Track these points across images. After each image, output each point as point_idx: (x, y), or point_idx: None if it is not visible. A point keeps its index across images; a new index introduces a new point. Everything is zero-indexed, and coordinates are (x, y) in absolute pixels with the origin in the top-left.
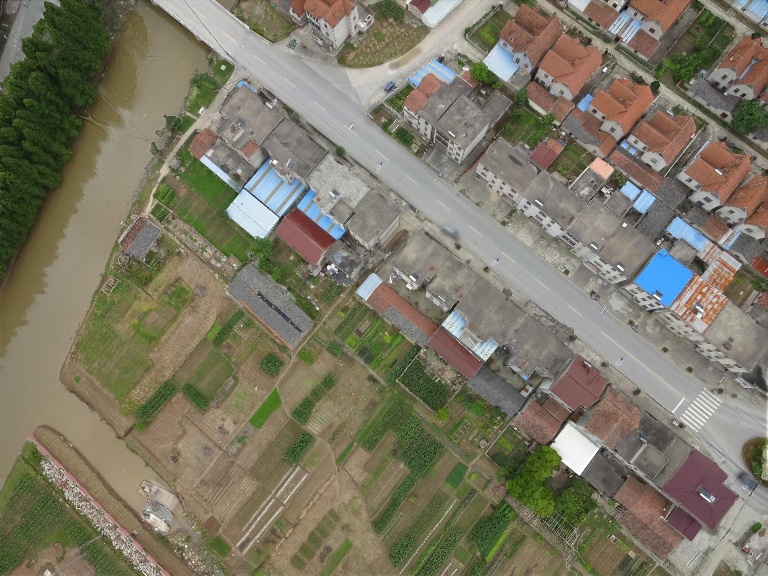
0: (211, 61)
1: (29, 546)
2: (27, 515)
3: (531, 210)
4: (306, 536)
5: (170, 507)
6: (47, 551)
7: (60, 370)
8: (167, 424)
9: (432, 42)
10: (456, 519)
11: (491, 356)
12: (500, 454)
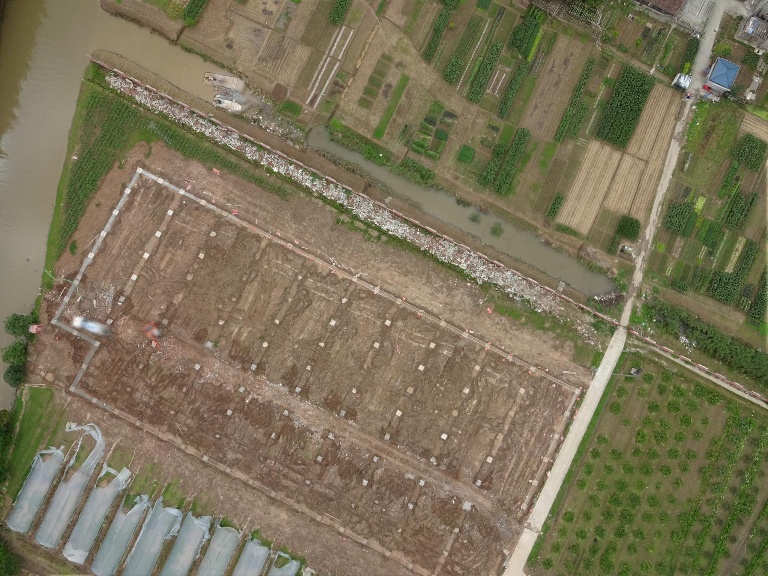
0: None
1: (116, 150)
2: (106, 123)
3: None
4: (366, 80)
5: (237, 89)
6: (134, 151)
7: (99, 0)
8: (214, 20)
9: None
10: (494, 34)
11: None
12: None
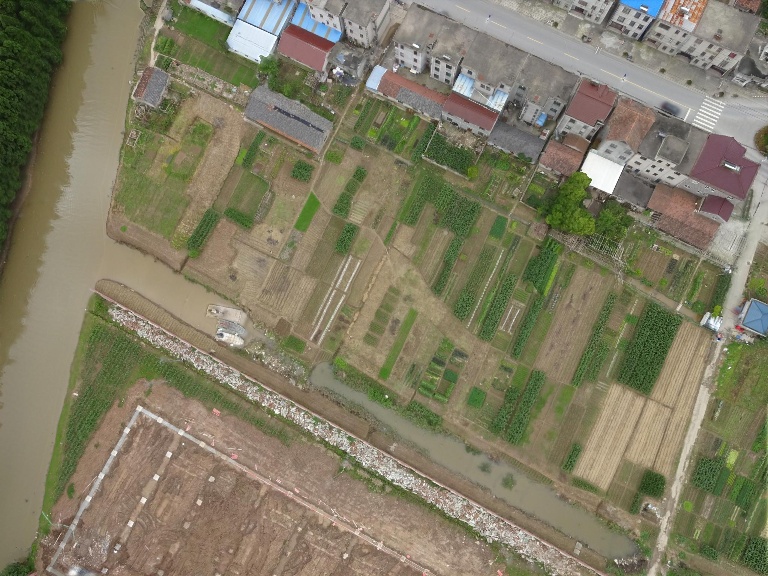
0: None
1: (116, 387)
2: (107, 360)
3: None
4: (373, 315)
5: (239, 322)
6: (134, 388)
7: (105, 227)
8: (218, 249)
9: None
10: (508, 266)
11: (504, 115)
12: (534, 194)
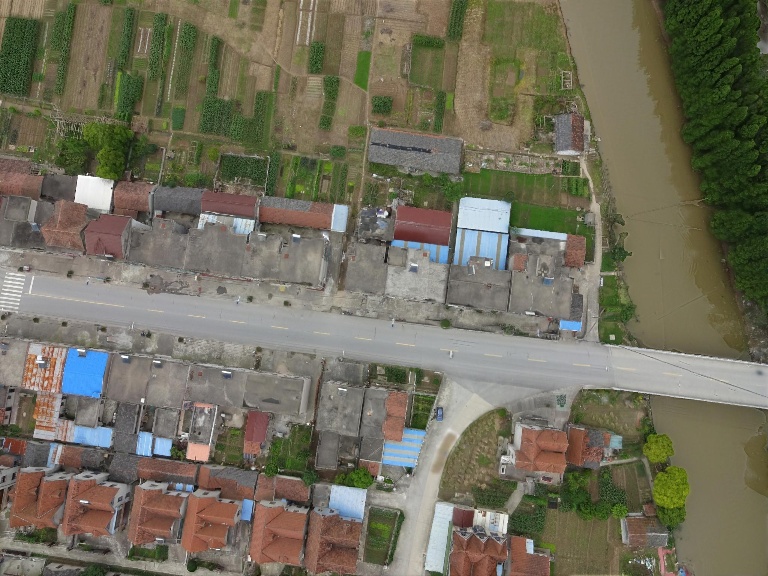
0: (630, 337)
1: None
2: None
3: (236, 369)
4: (269, 0)
5: None
6: None
7: None
8: (436, 7)
9: (429, 486)
10: None
11: None
12: None
